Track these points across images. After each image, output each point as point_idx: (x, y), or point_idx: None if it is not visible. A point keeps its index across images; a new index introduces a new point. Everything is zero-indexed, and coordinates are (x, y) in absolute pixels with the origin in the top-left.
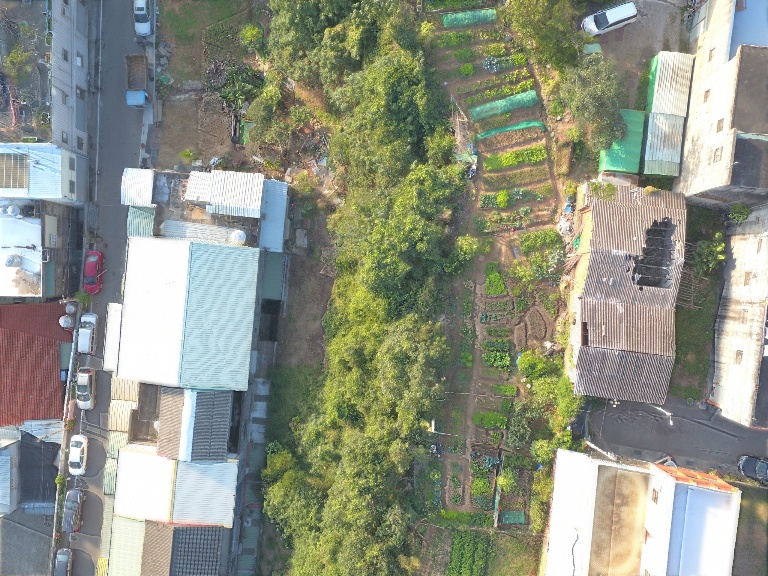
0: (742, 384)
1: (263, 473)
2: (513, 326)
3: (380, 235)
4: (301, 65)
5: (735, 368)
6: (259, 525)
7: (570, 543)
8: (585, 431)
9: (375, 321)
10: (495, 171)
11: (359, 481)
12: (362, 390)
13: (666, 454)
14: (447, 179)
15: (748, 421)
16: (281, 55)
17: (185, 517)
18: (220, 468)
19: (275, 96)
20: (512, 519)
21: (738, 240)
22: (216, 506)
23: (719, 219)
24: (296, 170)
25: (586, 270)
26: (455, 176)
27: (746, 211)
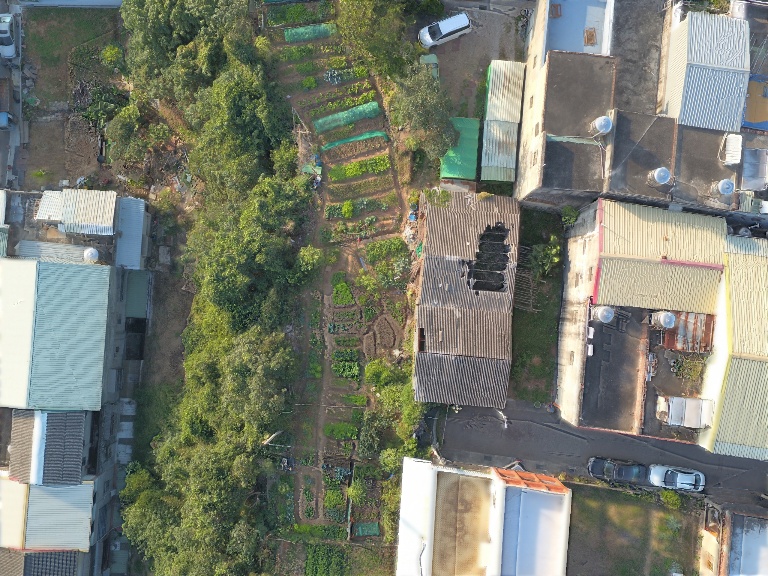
0: (573, 385)
1: (121, 494)
2: (362, 335)
3: (220, 248)
4: (155, 83)
5: (569, 369)
6: (128, 549)
7: (417, 552)
8: (433, 438)
9: (226, 335)
10: (340, 182)
11: (203, 497)
12: (213, 405)
13: (515, 459)
14: (291, 191)
15: (576, 421)
16: (139, 74)
17: (38, 542)
18: (74, 490)
19: (133, 114)
20: (366, 531)
21: (572, 242)
22: (71, 530)
23: (559, 223)
24: (159, 187)
25: (422, 276)
26: (300, 188)
27: (574, 213)
